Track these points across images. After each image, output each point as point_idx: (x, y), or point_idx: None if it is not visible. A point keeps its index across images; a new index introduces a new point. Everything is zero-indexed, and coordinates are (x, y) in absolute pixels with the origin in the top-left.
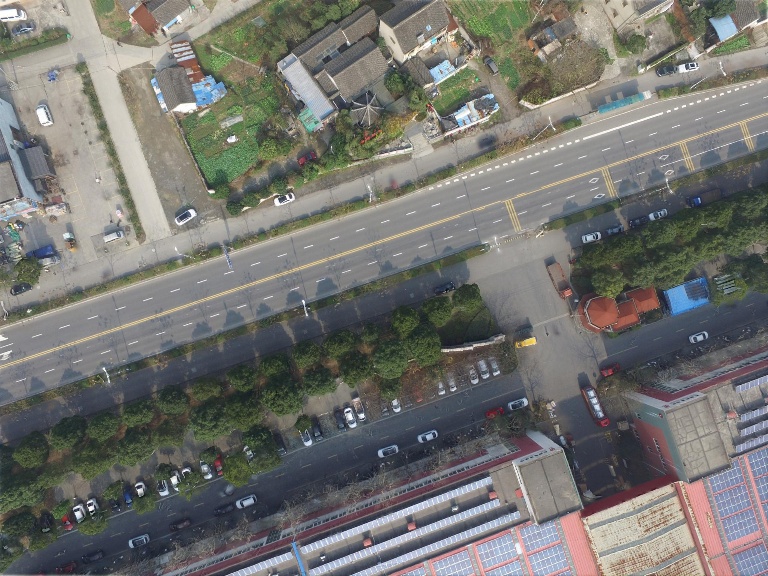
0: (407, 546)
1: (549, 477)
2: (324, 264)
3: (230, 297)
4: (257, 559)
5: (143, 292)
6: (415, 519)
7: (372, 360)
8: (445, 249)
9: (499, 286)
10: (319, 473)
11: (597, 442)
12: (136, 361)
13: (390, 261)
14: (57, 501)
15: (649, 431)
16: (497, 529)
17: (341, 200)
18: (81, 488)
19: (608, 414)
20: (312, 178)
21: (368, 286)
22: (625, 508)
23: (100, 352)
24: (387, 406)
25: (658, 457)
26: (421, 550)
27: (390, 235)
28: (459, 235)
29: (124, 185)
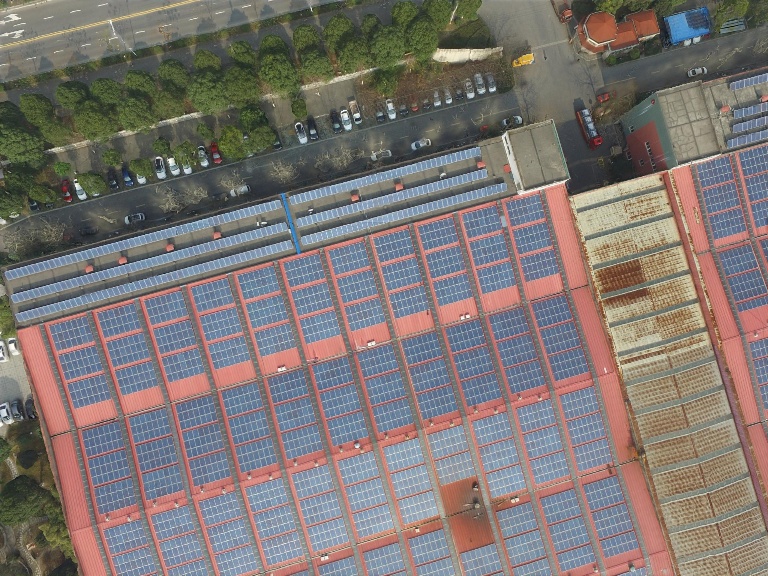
0: (394, 209)
1: (538, 147)
2: None
3: None
4: (247, 206)
5: None
6: (403, 184)
7: (370, 45)
8: None
9: (500, 8)
10: (313, 172)
11: (589, 167)
12: (142, 48)
13: None
14: (59, 175)
15: (641, 137)
16: (483, 201)
17: None
18: (82, 165)
19: None
20: None
21: None
22: (612, 193)
23: None
24: (383, 111)
25: (649, 163)
26: (407, 211)
27: None
28: None
29: None
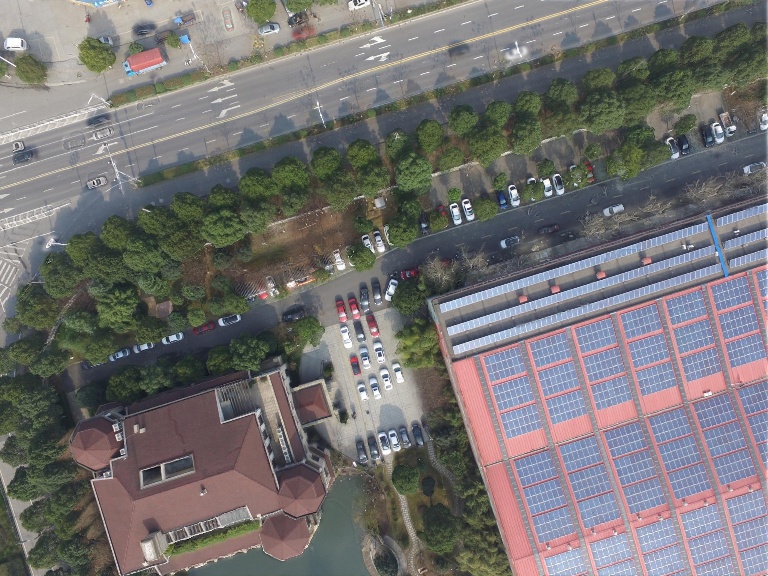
0: None
1: None
2: None
3: (599, 8)
4: (672, 230)
5: None
6: None
7: None
8: None
9: None
10: None
11: None
12: (509, 66)
13: None
14: (431, 200)
15: None
16: None
17: None
18: None
19: None
20: None
21: (739, 0)
22: None
23: (473, 57)
24: None
25: None
26: None
27: None
28: None
29: None
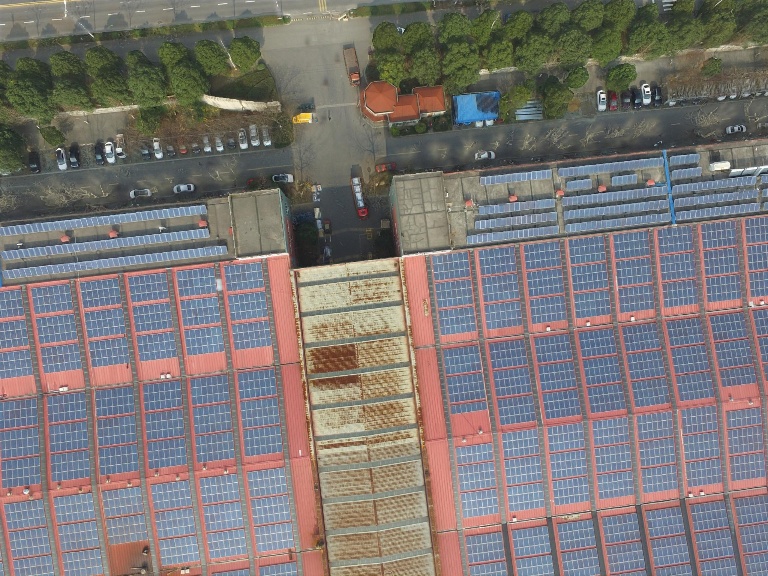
0: (107, 255)
1: (260, 215)
2: None
3: (19, 10)
4: None
5: None
6: (122, 231)
7: None
8: (244, 12)
9: (291, 61)
10: None
11: (356, 236)
12: None
13: (186, 11)
14: None
15: (394, 217)
16: (202, 261)
17: None
18: None
19: (374, 211)
20: None
21: (157, 29)
22: (339, 273)
23: None
24: (149, 149)
25: (397, 244)
26: (118, 260)
27: None
28: (262, 2)
29: None
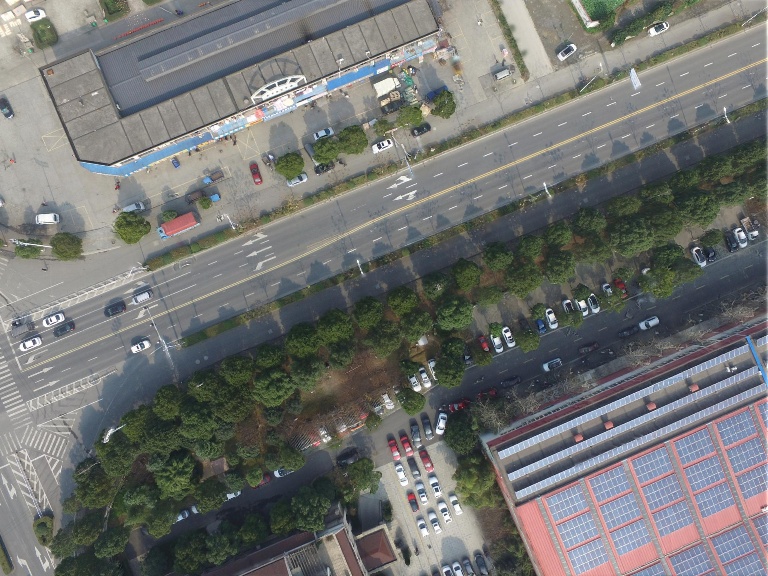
0: None
1: None
2: (701, 90)
3: (614, 128)
4: (714, 354)
5: (532, 128)
6: None
7: None
8: None
9: None
10: (713, 294)
11: None
12: (534, 193)
13: (763, 84)
14: (472, 331)
15: None
16: None
17: (711, 27)
18: (493, 317)
19: None
20: (696, 0)
21: (747, 108)
22: None
23: (498, 187)
24: None
25: None
26: None
27: (761, 58)
28: None
29: (505, 25)
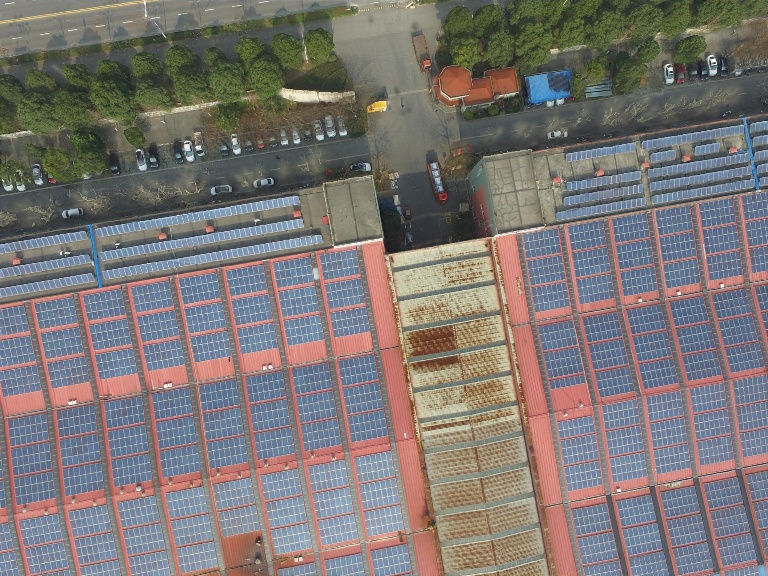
0: (204, 250)
1: (354, 202)
2: None
3: (90, 15)
4: (52, 234)
5: None
6: (217, 226)
7: (208, 79)
8: (312, 5)
9: (361, 51)
10: None
11: (436, 221)
12: None
13: (255, 7)
14: None
15: (478, 198)
16: (298, 251)
17: None
18: None
19: (451, 195)
20: None
21: (228, 26)
22: (432, 255)
23: None
24: (227, 145)
25: (483, 225)
26: (216, 254)
27: None
28: None
29: None
